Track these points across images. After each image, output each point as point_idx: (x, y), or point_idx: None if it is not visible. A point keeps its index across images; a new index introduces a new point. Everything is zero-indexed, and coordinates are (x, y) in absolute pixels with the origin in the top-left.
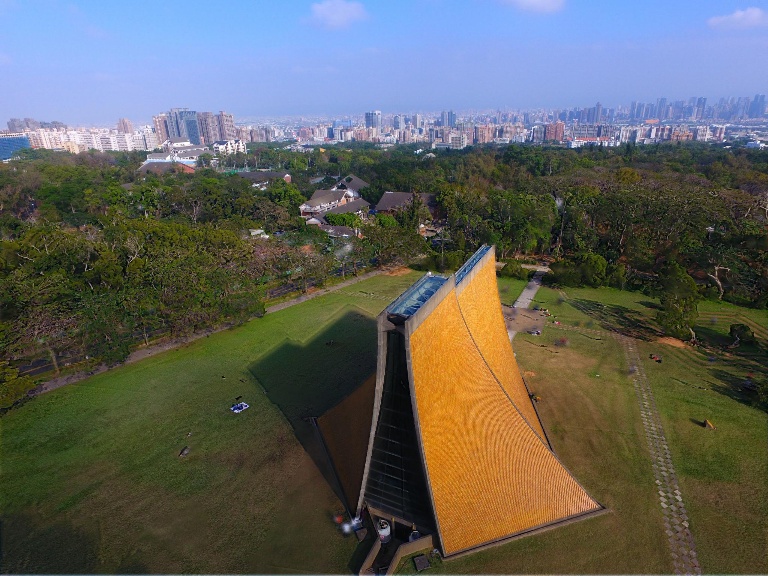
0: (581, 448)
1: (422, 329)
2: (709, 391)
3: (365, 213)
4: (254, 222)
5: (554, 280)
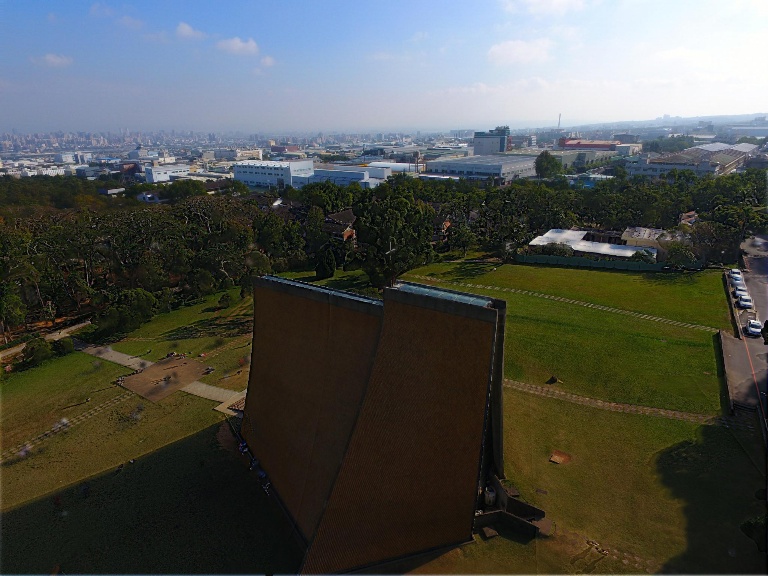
0: None
1: None
2: None
3: None
4: None
5: (103, 335)
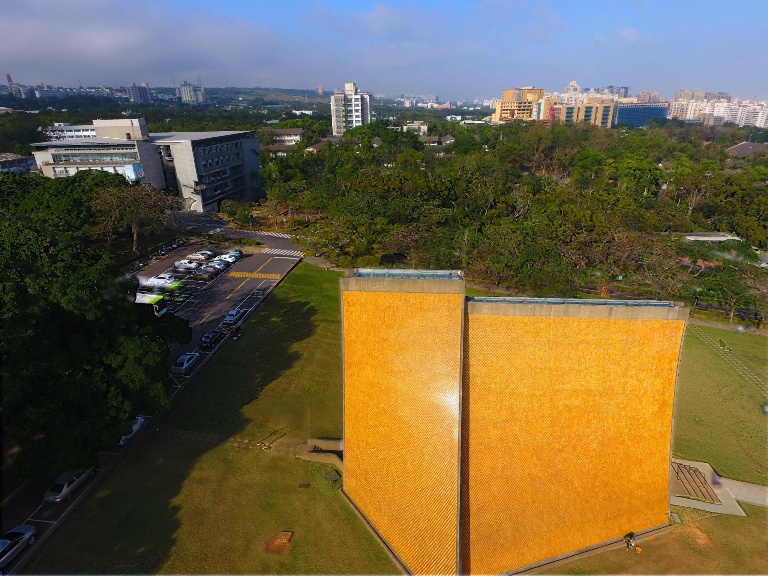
0: None
1: (369, 297)
2: None
3: None
4: (765, 230)
5: None
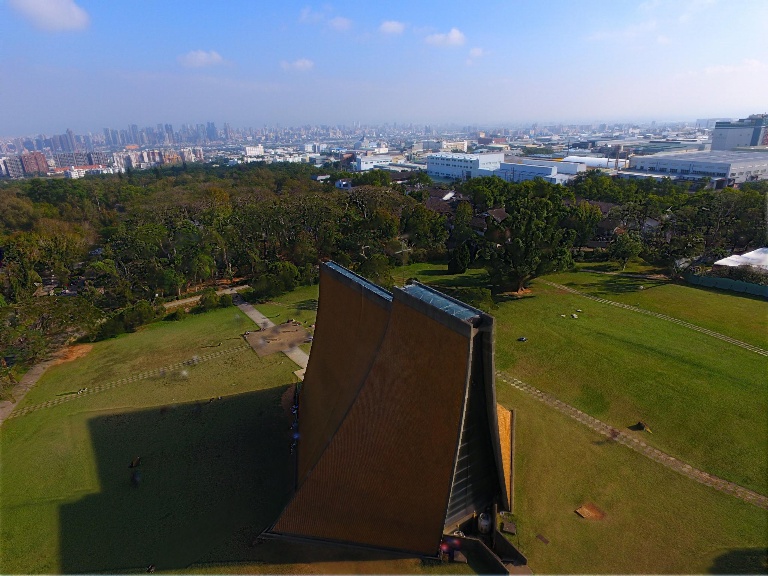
0: None
1: None
2: None
3: None
4: None
5: (256, 296)
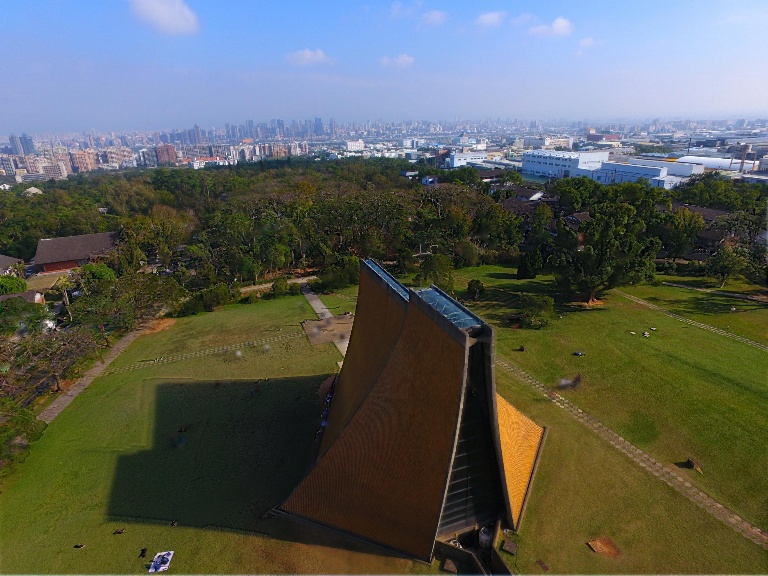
0: None
1: None
2: (499, 329)
3: (20, 272)
4: None
5: (323, 287)
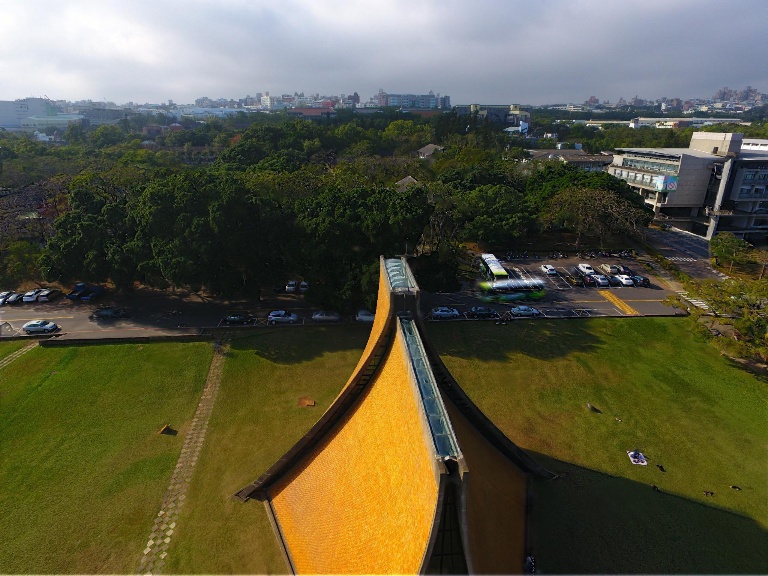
0: (246, 568)
1: None
2: None
3: None
4: None
5: None
